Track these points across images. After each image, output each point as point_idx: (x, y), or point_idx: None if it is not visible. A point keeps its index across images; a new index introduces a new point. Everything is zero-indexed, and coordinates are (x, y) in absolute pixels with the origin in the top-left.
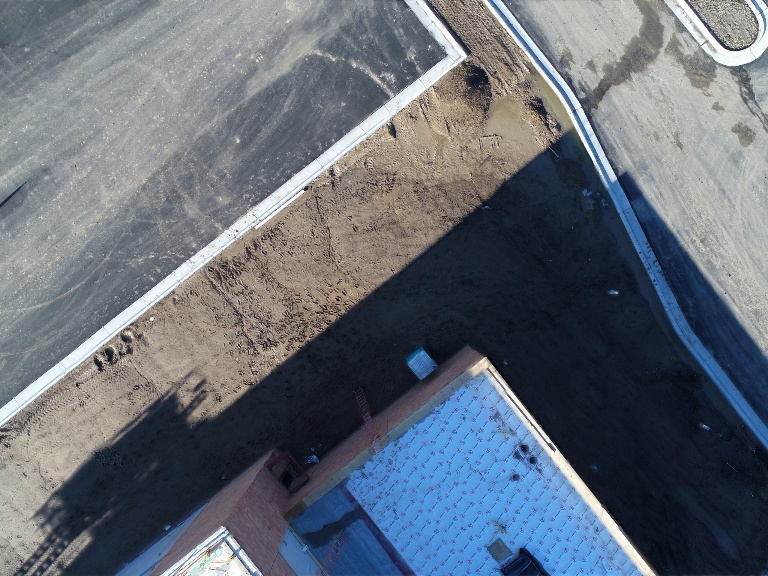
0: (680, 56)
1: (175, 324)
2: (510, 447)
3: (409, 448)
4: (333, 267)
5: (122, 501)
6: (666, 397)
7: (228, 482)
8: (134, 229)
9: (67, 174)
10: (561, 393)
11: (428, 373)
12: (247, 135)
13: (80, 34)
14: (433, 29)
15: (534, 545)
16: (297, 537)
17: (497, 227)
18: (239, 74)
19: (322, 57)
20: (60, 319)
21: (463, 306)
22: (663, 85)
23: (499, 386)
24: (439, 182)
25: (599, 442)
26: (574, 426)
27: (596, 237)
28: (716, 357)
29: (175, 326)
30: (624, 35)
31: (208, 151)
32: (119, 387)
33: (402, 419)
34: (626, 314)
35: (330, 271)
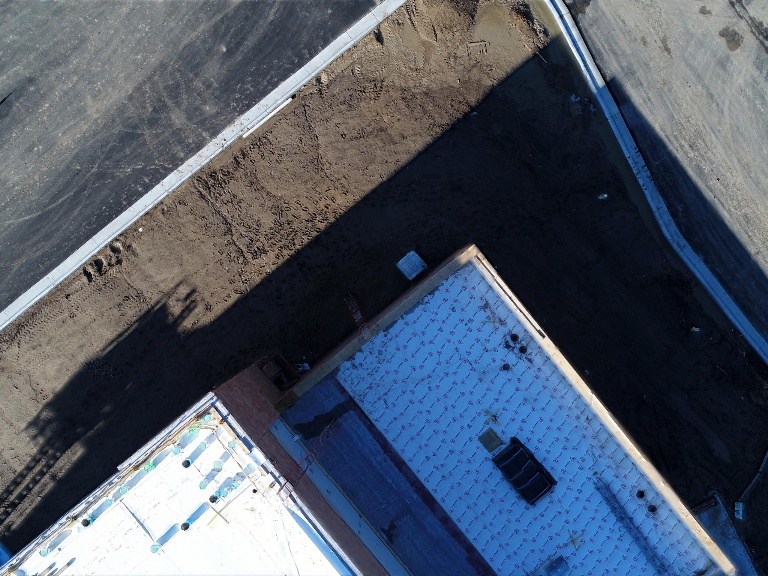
0: None
1: (164, 234)
2: (500, 337)
3: (399, 339)
4: (322, 175)
5: (114, 412)
6: (656, 301)
7: None
8: (121, 139)
9: (53, 85)
10: (551, 298)
11: (418, 273)
12: (233, 43)
13: None
14: None
15: (525, 434)
16: (288, 427)
17: (486, 133)
18: None
19: None
20: (48, 231)
21: (452, 212)
22: None
23: (488, 273)
24: (427, 89)
25: (590, 346)
26: (565, 331)
27: (585, 142)
28: (705, 261)
29: (164, 236)
30: None
31: (194, 60)
32: (109, 298)
33: (391, 309)
34: (615, 219)
35: (319, 179)
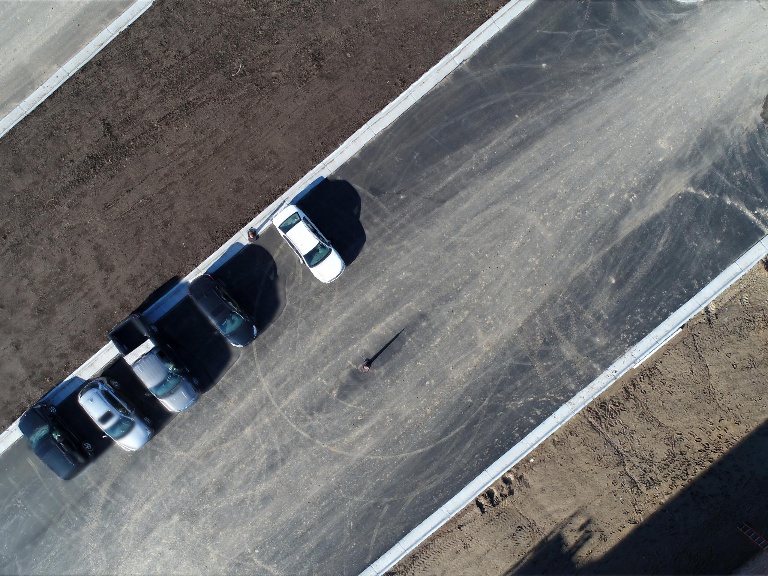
0: None
1: (556, 465)
2: None
3: None
4: (714, 405)
5: None
6: None
7: None
8: (512, 372)
9: (444, 319)
10: None
11: None
12: (622, 275)
13: (455, 179)
14: None
15: None
16: None
17: None
18: (613, 214)
19: (696, 194)
20: (441, 463)
21: None
22: None
23: None
24: None
25: None
26: None
27: None
28: None
29: (556, 467)
30: None
31: (584, 292)
32: (502, 529)
33: None
34: None
35: (711, 409)
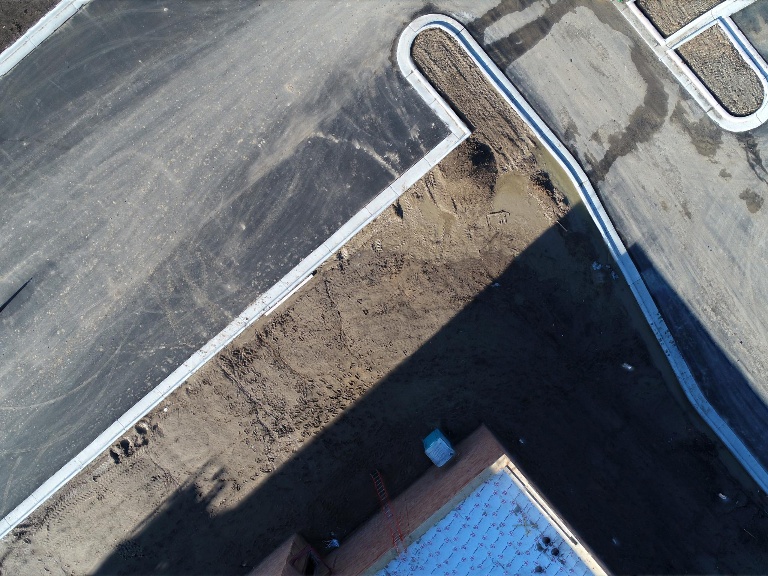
0: (686, 124)
1: (189, 414)
2: (531, 539)
3: (431, 545)
4: (345, 351)
5: None
6: (682, 467)
7: (249, 569)
8: (143, 321)
9: (73, 268)
10: (577, 467)
11: (445, 460)
12: (253, 221)
13: (79, 126)
14: (436, 107)
15: None
16: None
17: (508, 304)
18: (242, 160)
19: (325, 139)
20: (73, 414)
21: (477, 385)
22: (669, 154)
23: (519, 483)
24: (448, 261)
25: (616, 514)
26: (591, 499)
27: (607, 310)
28: (730, 424)
29: (189, 416)
30: (629, 105)
31: (214, 239)
32: (136, 479)
33: (423, 517)
34: (639, 386)
35: (342, 355)
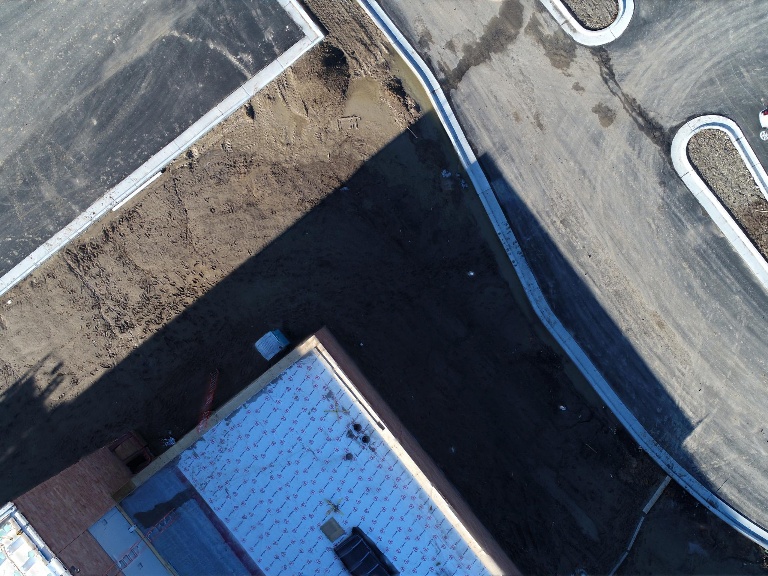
0: (540, 36)
1: (32, 307)
2: (343, 426)
3: (241, 427)
4: (190, 249)
5: None
6: (525, 378)
7: None
8: None
9: None
10: (420, 374)
11: (274, 354)
12: (104, 117)
13: None
14: (291, 9)
15: (367, 524)
16: (126, 517)
17: (355, 208)
18: (96, 55)
19: (179, 38)
20: None
21: (321, 288)
22: (523, 65)
23: (327, 364)
24: (297, 163)
25: (458, 423)
26: (432, 407)
27: (455, 218)
28: (576, 338)
29: (32, 309)
30: (484, 15)
31: (65, 133)
32: None
33: None
34: (485, 295)
35: (187, 253)
